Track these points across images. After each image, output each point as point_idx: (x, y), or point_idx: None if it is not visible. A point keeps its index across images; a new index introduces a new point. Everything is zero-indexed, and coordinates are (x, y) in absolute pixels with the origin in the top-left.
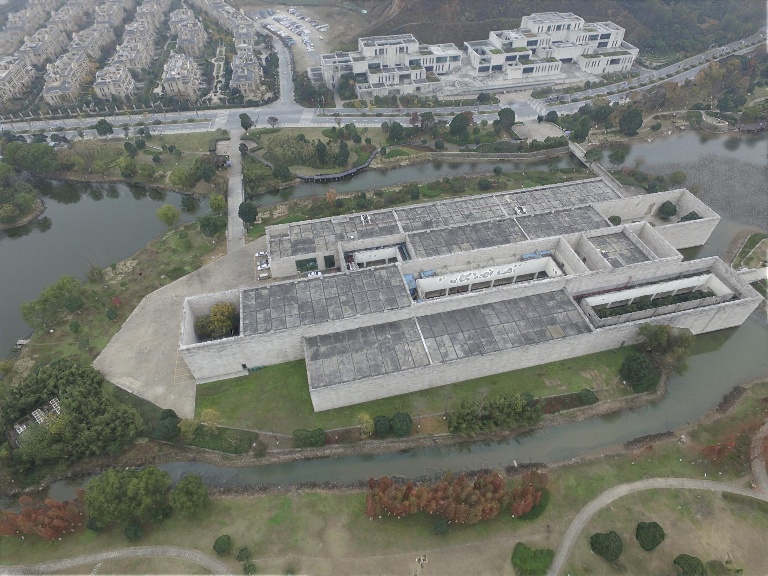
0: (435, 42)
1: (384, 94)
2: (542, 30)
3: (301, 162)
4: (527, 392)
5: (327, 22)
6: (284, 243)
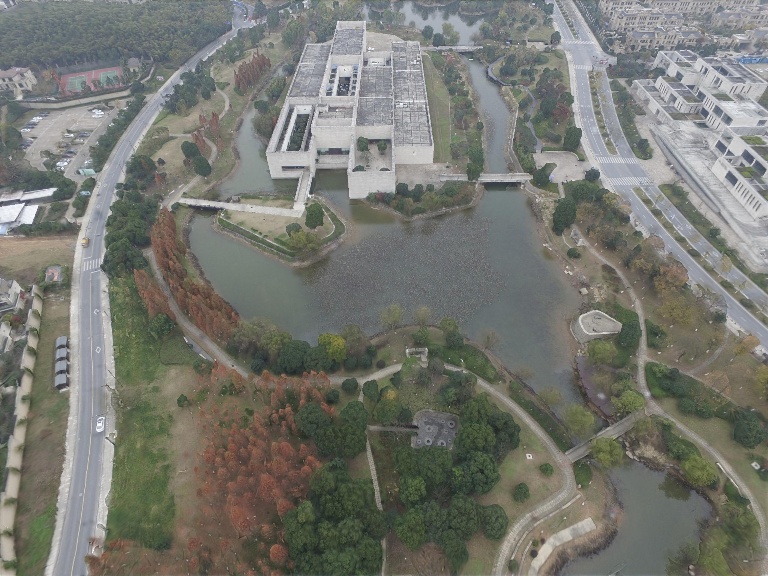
0: None
1: (642, 97)
2: None
3: None
4: None
5: None
6: None
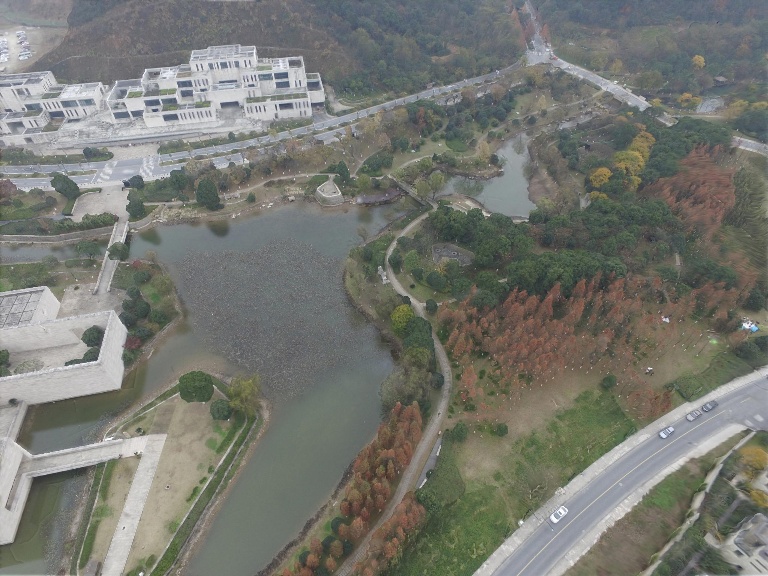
0: (99, 79)
1: None
2: (203, 68)
3: None
4: None
5: (41, 48)
6: None
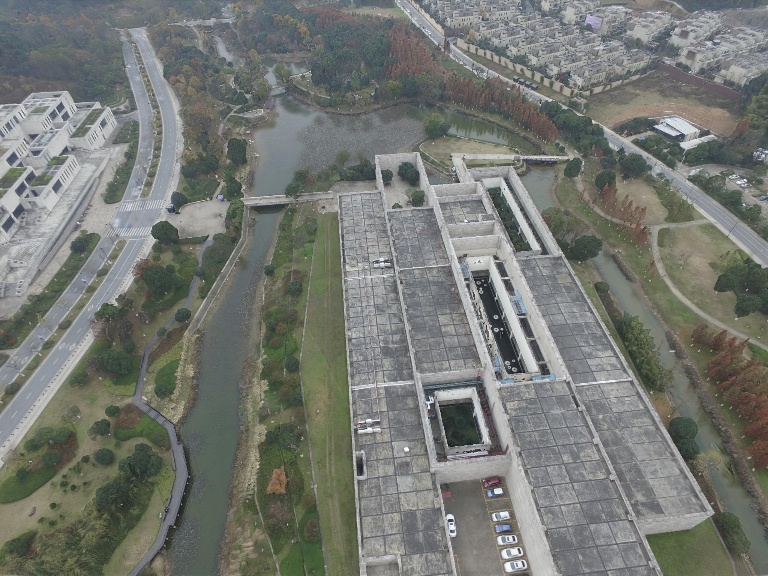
0: None
1: None
2: None
3: (102, 554)
4: (623, 319)
5: None
6: (410, 568)
